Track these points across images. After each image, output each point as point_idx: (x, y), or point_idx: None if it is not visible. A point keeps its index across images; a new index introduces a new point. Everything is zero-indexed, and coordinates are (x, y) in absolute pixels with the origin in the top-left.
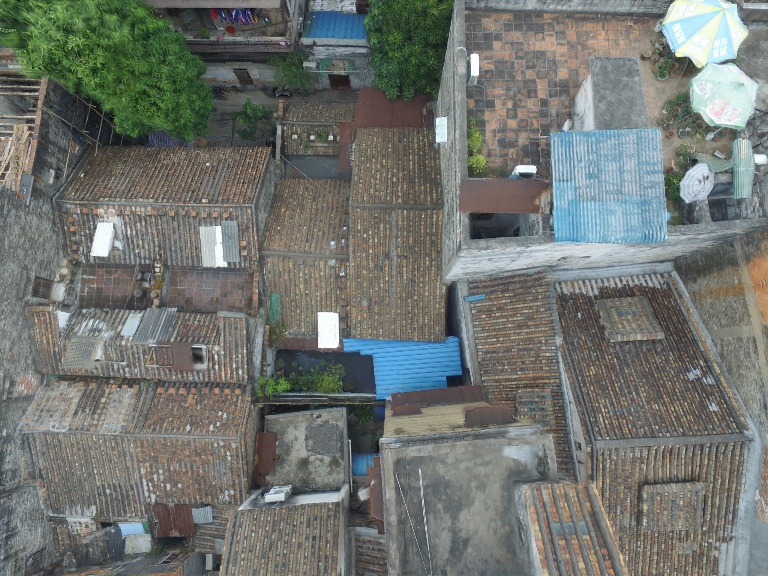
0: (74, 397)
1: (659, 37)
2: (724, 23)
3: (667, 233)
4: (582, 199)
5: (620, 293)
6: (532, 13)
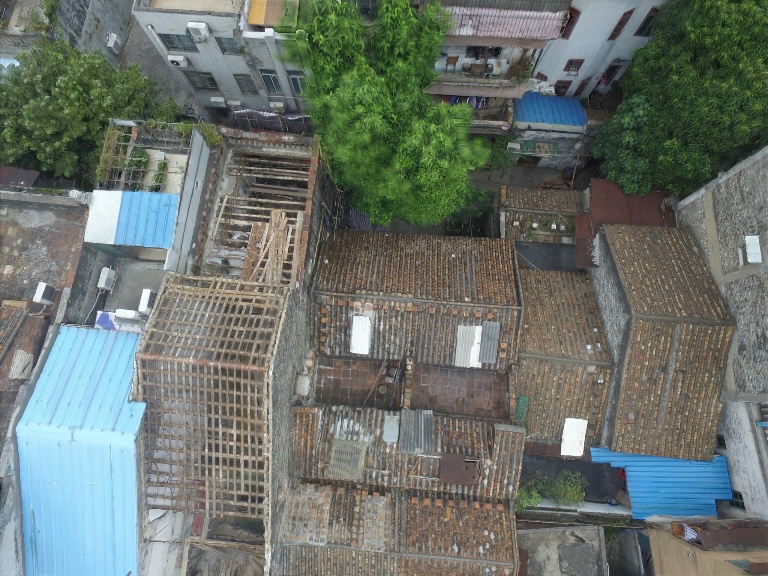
0: (324, 503)
1: None
2: None
3: None
4: None
5: None
6: None
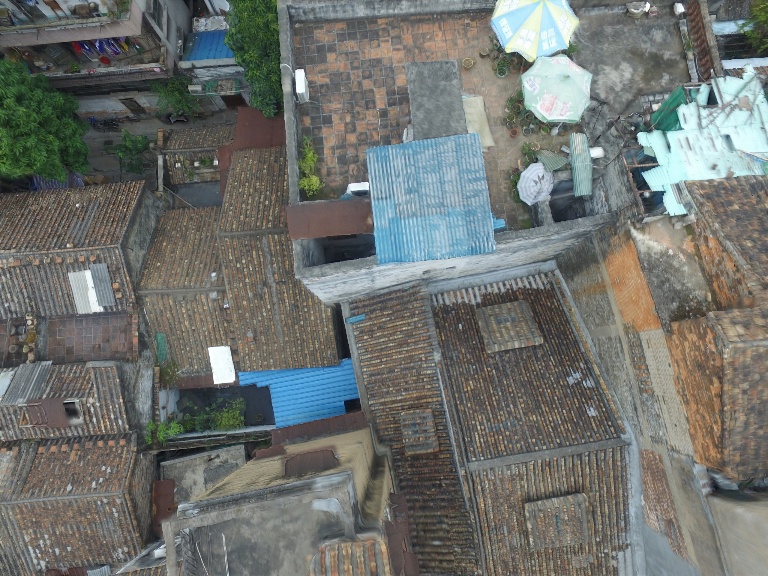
0: None
1: None
2: (547, 14)
3: (495, 243)
4: (403, 216)
5: (503, 298)
6: (365, 20)
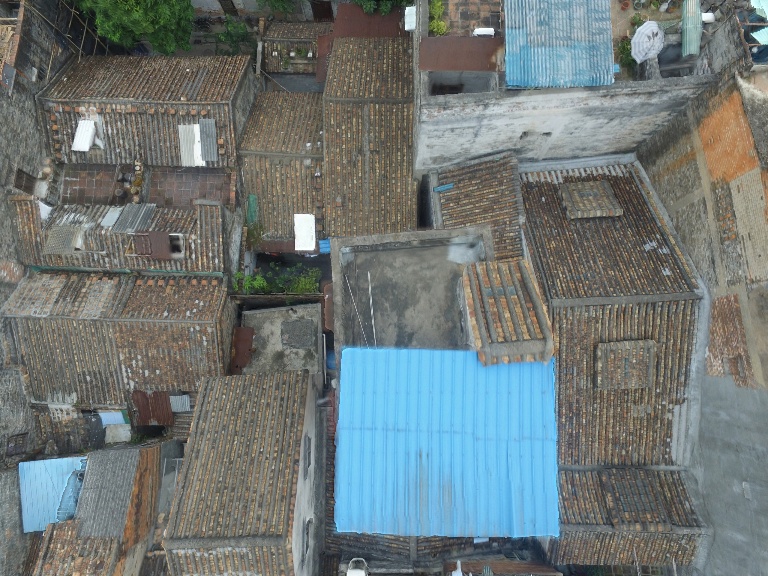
0: (56, 288)
1: None
2: None
3: None
4: (533, 45)
5: (584, 181)
6: None
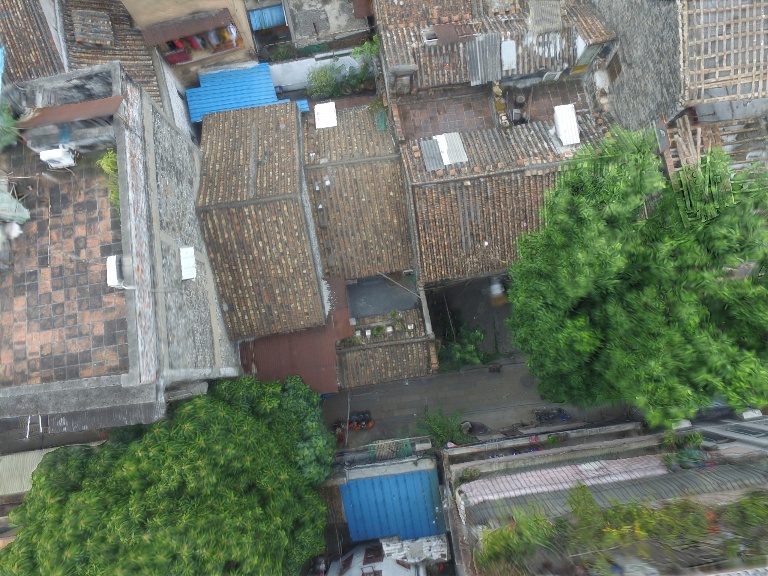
0: None
1: None
2: None
3: None
4: None
5: None
6: None
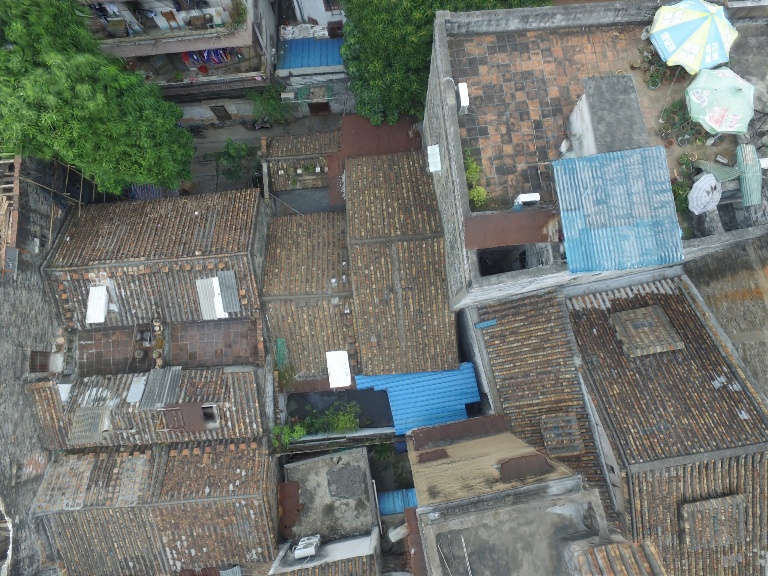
0: (85, 471)
1: (646, 45)
2: (713, 28)
3: None
4: (593, 227)
5: (633, 303)
6: (515, 33)
